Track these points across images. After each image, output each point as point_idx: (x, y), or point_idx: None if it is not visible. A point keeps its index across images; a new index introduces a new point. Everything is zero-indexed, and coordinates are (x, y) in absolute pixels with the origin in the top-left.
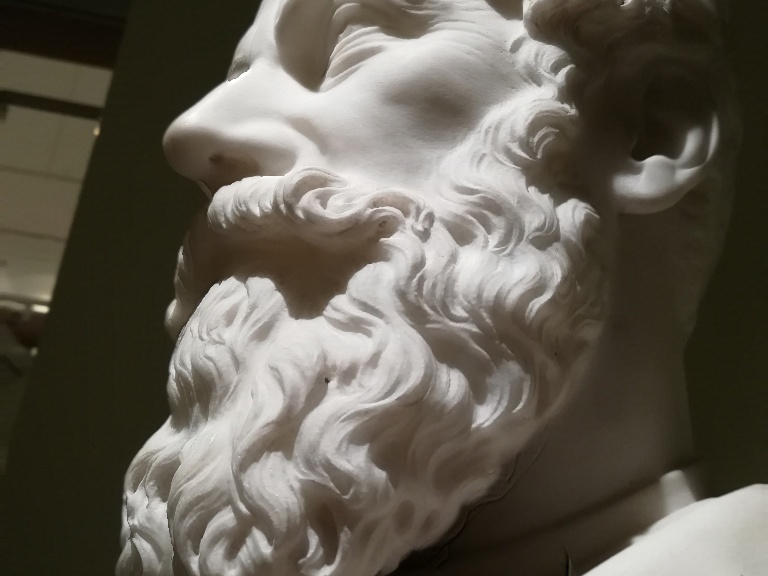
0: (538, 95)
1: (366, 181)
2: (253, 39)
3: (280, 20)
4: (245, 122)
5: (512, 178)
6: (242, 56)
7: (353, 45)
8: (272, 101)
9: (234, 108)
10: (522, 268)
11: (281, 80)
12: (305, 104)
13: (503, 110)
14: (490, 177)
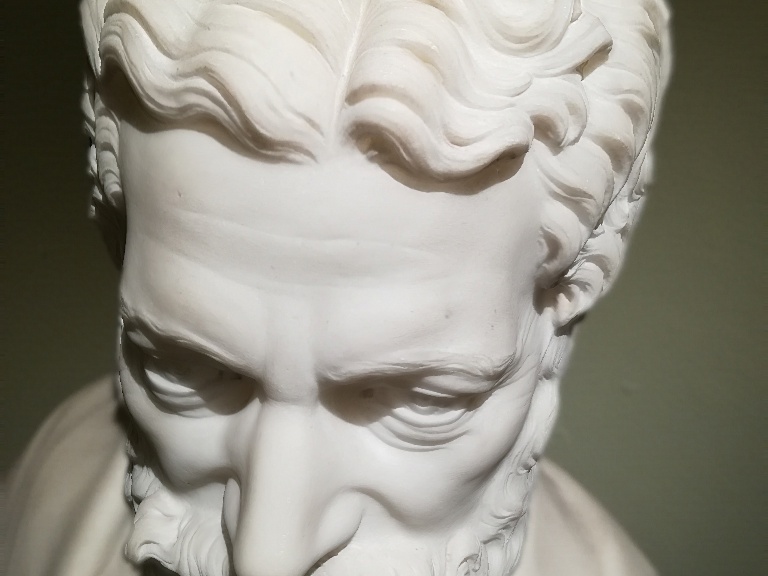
0: (550, 401)
1: (439, 543)
2: (275, 366)
3: (341, 383)
4: (323, 521)
5: (523, 483)
6: (243, 365)
7: (440, 432)
8: (338, 478)
9: (313, 516)
10: (517, 541)
11: (331, 432)
12: (375, 475)
13: (529, 430)
14: (513, 493)
